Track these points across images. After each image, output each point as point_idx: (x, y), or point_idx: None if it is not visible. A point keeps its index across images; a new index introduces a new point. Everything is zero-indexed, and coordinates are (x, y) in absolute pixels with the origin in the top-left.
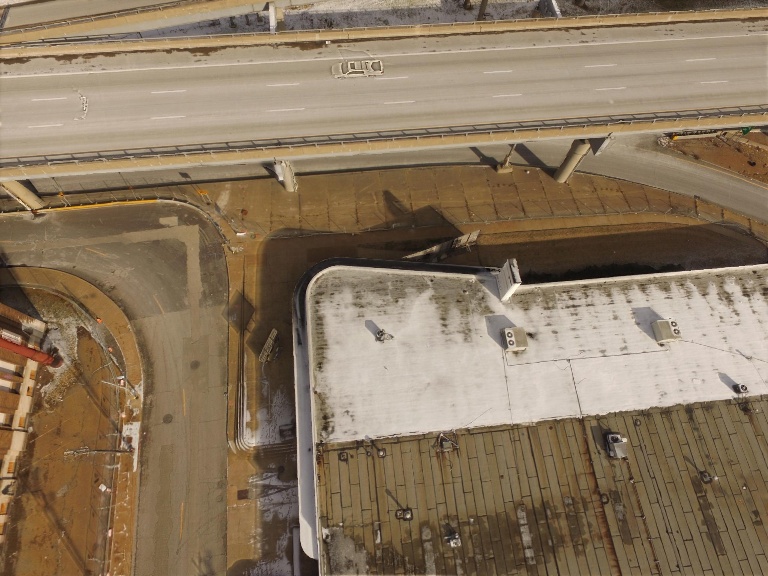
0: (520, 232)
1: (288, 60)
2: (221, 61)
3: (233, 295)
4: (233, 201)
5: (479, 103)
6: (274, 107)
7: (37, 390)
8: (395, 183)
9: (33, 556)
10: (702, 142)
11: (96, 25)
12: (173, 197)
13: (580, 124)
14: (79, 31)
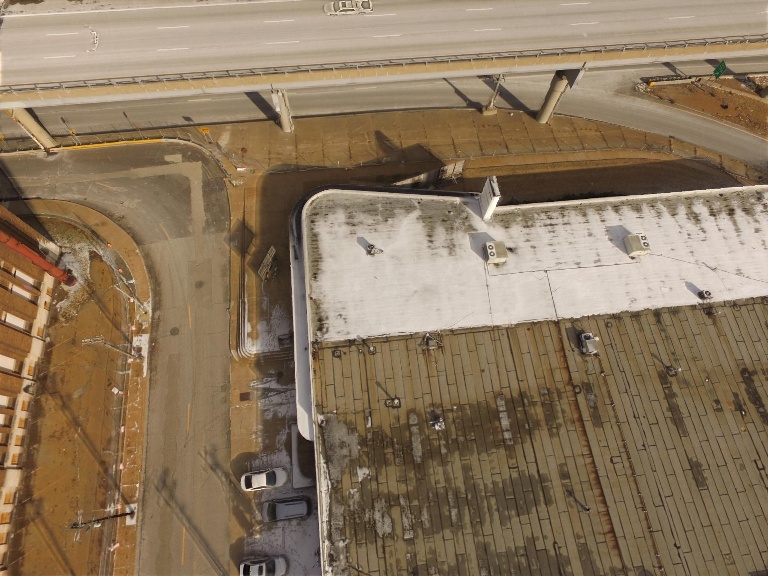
0: (503, 166)
1: None
2: (221, 1)
3: (234, 223)
4: (233, 141)
5: (461, 36)
6: (271, 40)
7: (53, 306)
8: (386, 124)
9: (52, 448)
10: (678, 88)
11: None
12: (177, 136)
13: (555, 53)
14: None
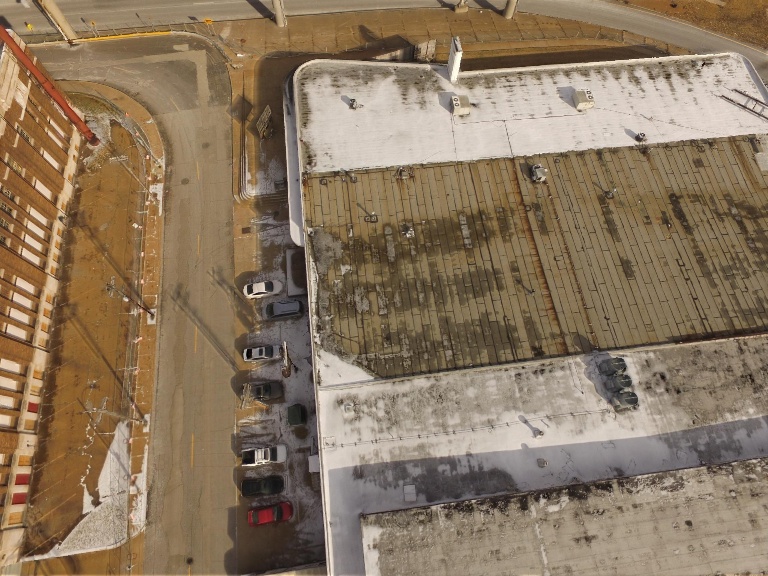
0: (472, 51)
1: None
2: None
3: (235, 98)
4: (234, 34)
5: None
6: None
7: (80, 160)
8: (369, 20)
9: (84, 267)
10: None
11: None
12: (184, 29)
13: None
14: None
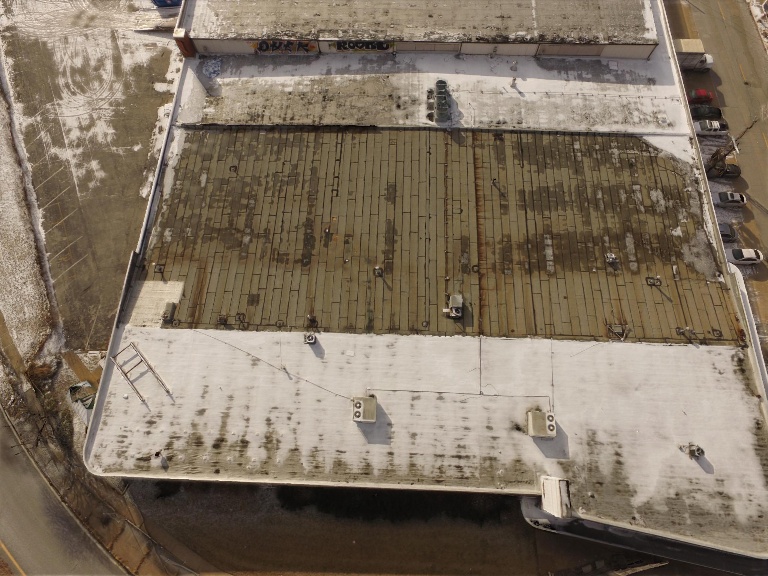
0: None
1: None
2: None
3: None
4: None
5: None
6: None
7: None
8: None
9: None
10: None
11: None
12: None
13: None
14: None
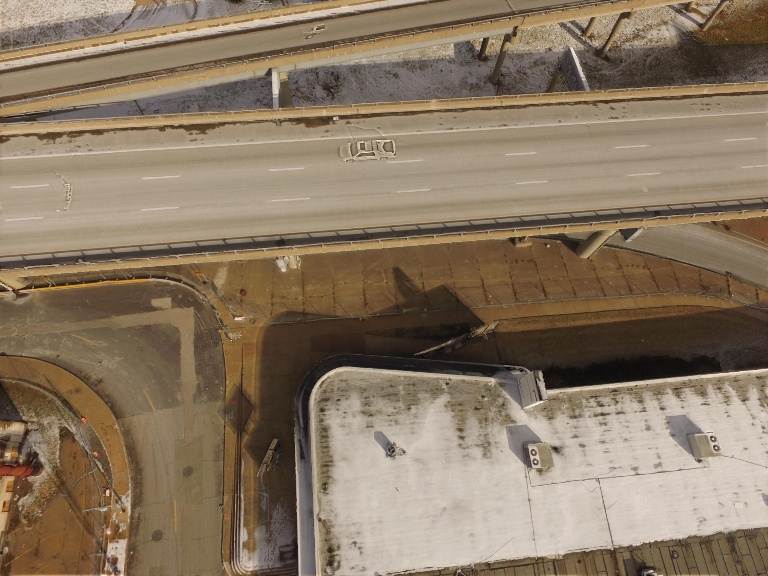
0: (541, 317)
1: (292, 139)
2: (219, 141)
3: (230, 389)
4: (231, 279)
5: (501, 192)
6: (276, 196)
7: (14, 503)
8: (406, 259)
9: None
10: None
11: (83, 97)
12: (166, 276)
13: (612, 218)
14: (65, 103)
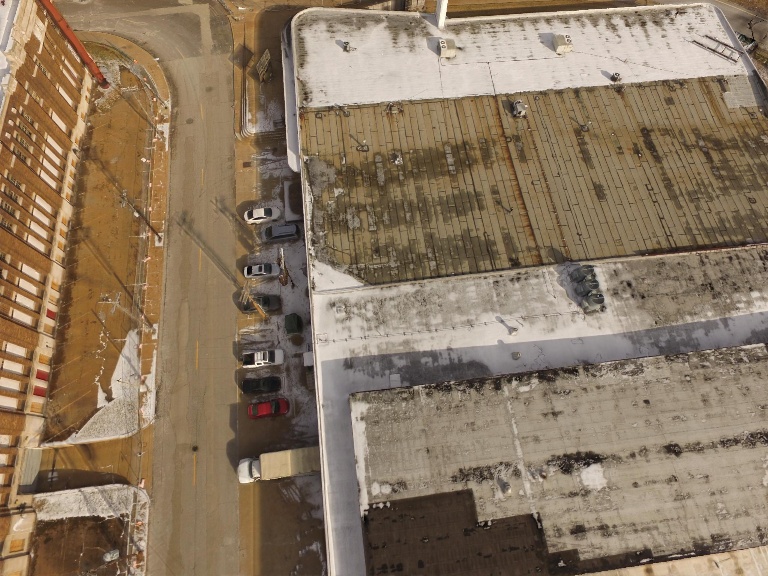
0: (460, 5)
1: None
2: None
3: (237, 47)
4: None
5: None
6: None
7: (92, 102)
8: None
9: (96, 195)
10: None
11: None
12: None
13: None
14: None
